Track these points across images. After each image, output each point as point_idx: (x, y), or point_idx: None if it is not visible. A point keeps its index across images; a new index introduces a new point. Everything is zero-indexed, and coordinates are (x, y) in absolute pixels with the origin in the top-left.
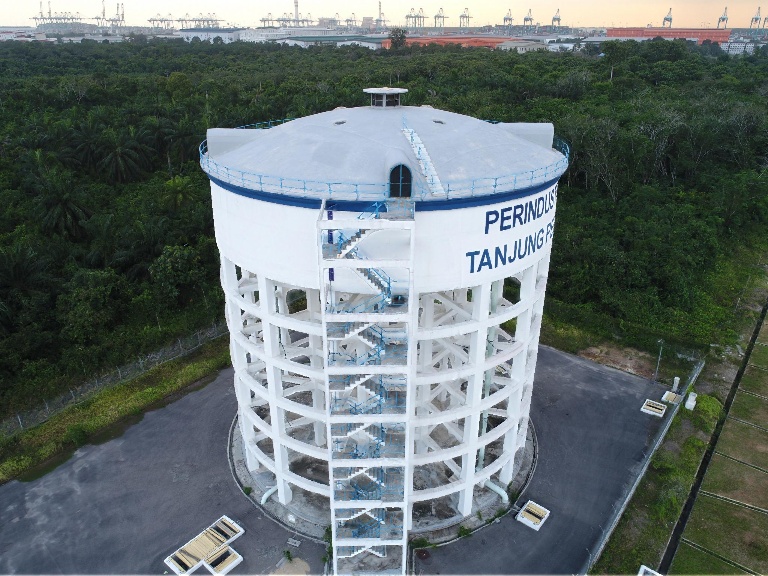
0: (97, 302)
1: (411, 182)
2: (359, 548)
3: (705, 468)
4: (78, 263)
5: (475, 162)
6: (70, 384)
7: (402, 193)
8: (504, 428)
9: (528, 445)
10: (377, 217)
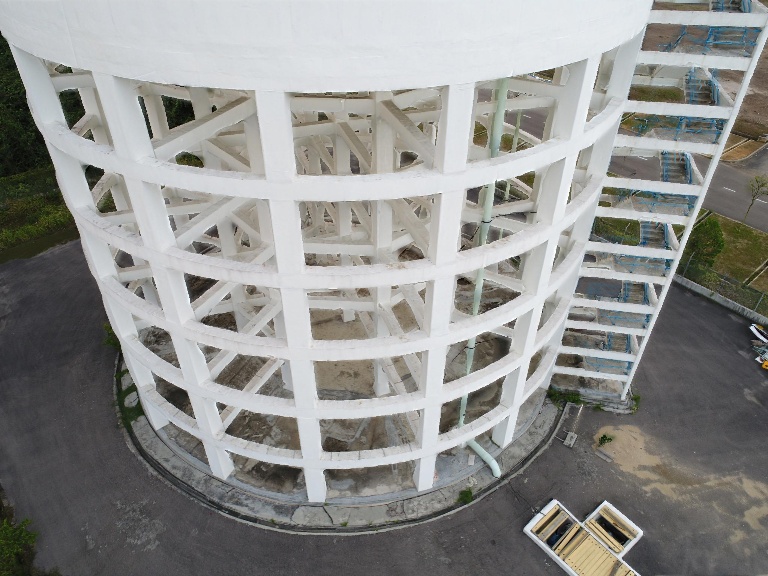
0: None
1: None
2: None
3: None
4: None
5: None
6: None
7: None
8: None
9: None
10: None
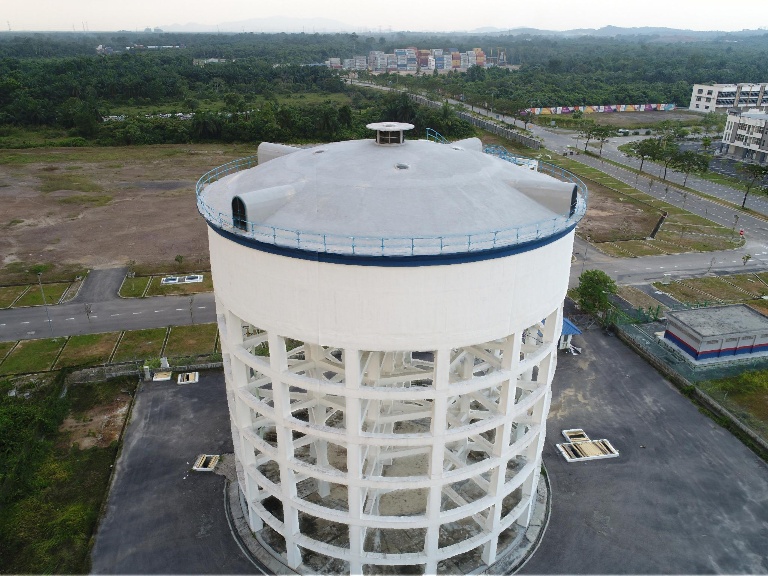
0: None
1: None
2: None
3: None
4: None
5: None
6: None
7: None
8: None
9: None
10: None
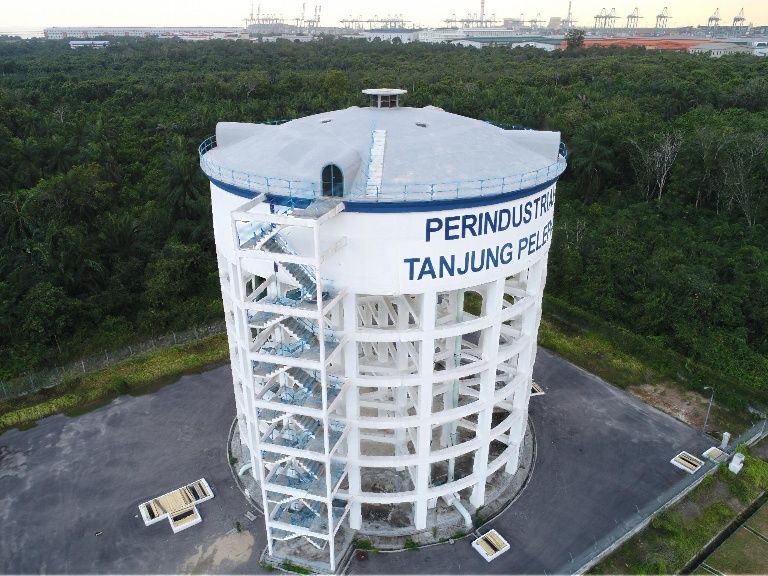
0: (176, 273)
1: (342, 182)
2: (291, 534)
3: (724, 541)
4: (179, 237)
5: (430, 167)
6: (136, 341)
7: (334, 192)
8: (465, 447)
9: (520, 473)
10: (286, 213)
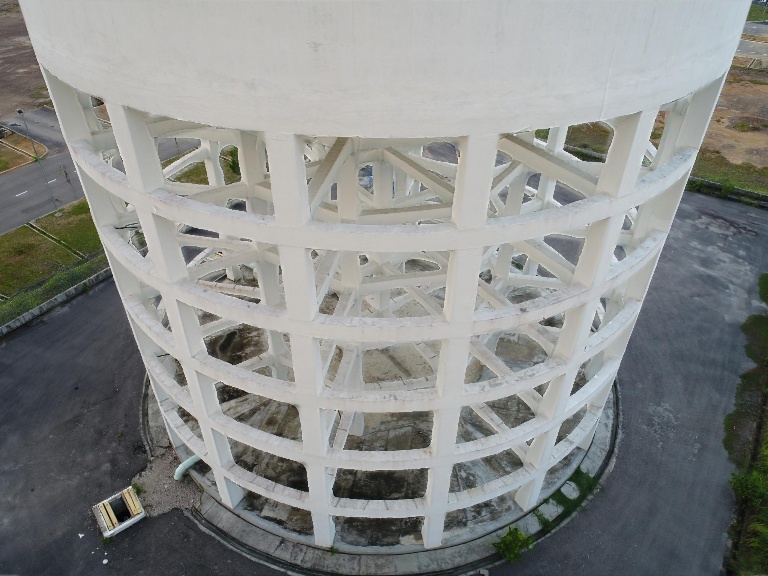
0: None
1: None
2: None
3: None
4: None
5: None
6: None
7: None
8: None
9: None
10: None
